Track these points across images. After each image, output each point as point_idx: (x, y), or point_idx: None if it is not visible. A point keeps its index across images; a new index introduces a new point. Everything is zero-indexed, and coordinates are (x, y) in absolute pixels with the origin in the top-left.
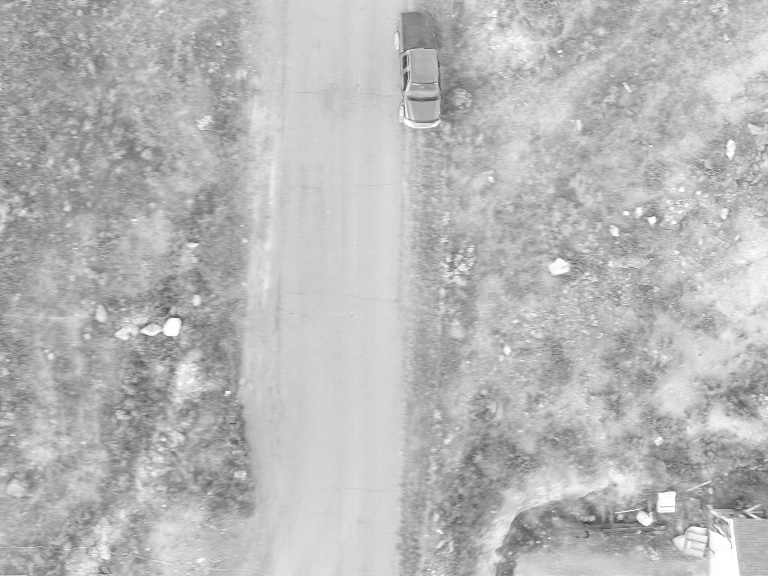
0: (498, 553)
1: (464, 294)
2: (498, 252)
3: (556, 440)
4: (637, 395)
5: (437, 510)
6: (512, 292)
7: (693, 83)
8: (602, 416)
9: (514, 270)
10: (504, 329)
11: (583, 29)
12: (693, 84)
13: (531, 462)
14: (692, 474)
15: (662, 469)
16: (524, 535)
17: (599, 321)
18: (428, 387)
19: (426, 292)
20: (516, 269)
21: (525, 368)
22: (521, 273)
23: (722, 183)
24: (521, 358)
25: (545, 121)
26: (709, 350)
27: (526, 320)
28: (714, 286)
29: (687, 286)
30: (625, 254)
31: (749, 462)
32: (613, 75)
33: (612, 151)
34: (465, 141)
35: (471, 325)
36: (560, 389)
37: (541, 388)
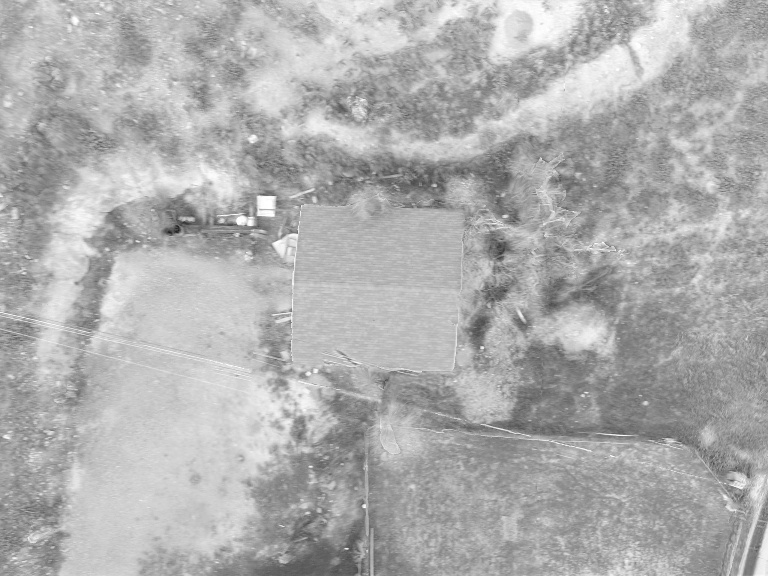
0: (90, 244)
1: None
2: None
3: (135, 122)
4: (225, 87)
5: None
6: None
7: None
8: (185, 103)
9: None
10: None
11: None
12: None
13: (106, 141)
14: (290, 177)
15: (249, 162)
16: (122, 232)
17: (175, 1)
18: None
19: None
20: None
21: (97, 42)
22: None
23: None
24: (91, 30)
25: None
26: (311, 53)
27: None
28: None
29: None
30: None
31: (353, 171)
32: None
33: None
34: None
35: None
36: (139, 71)
37: (117, 66)
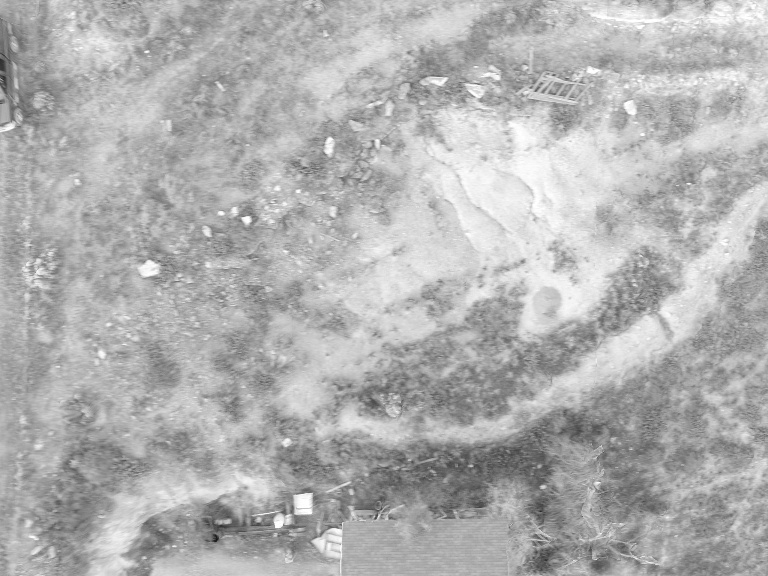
0: (127, 558)
1: (49, 298)
2: (87, 255)
3: (167, 443)
4: (256, 396)
5: (29, 516)
6: (102, 295)
7: (292, 80)
8: (217, 418)
9: (103, 273)
10: (98, 333)
11: (171, 29)
12: (292, 81)
13: (140, 466)
14: (326, 475)
15: (285, 471)
16: (158, 539)
17: (202, 323)
18: (14, 392)
19: (11, 297)
20: (106, 272)
21: (125, 371)
22: (111, 276)
23: (323, 181)
24: (119, 361)
25: (133, 122)
26: (340, 350)
27: (120, 323)
28: (339, 285)
29: (308, 285)
30: (220, 255)
31: (388, 462)
32: (205, 74)
33: (206, 151)
34: (50, 144)
35: (59, 329)
36: (169, 392)
37: (147, 391)
